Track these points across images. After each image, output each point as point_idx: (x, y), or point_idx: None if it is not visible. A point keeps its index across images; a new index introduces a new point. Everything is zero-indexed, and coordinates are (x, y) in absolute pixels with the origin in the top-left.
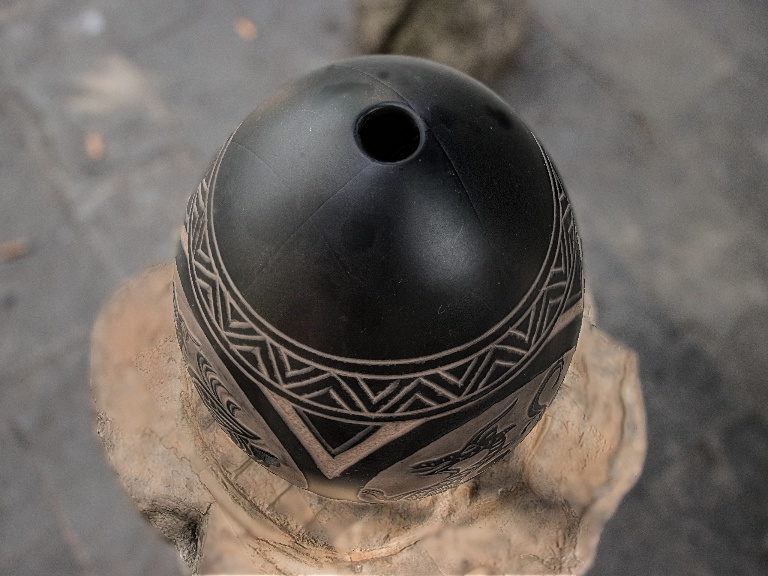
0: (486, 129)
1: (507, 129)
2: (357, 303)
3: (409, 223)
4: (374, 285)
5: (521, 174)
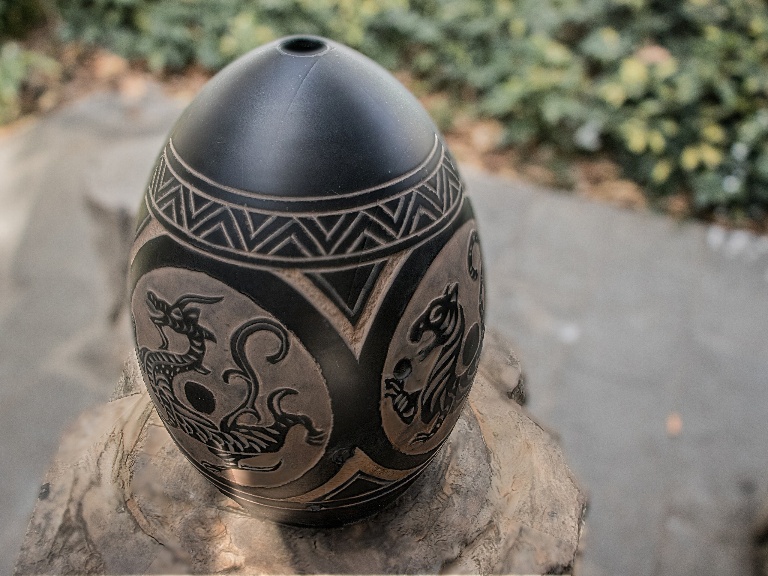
0: (360, 97)
1: (381, 121)
2: (199, 108)
3: (254, 80)
4: (212, 101)
5: (350, 135)
